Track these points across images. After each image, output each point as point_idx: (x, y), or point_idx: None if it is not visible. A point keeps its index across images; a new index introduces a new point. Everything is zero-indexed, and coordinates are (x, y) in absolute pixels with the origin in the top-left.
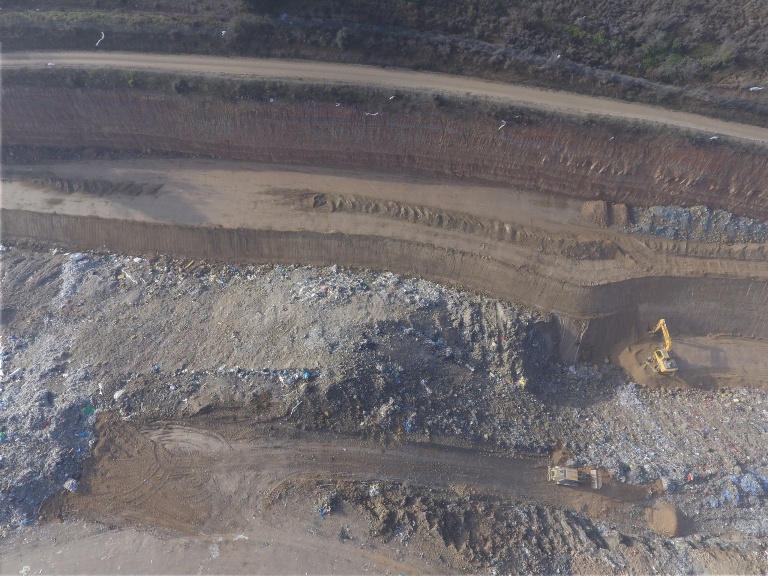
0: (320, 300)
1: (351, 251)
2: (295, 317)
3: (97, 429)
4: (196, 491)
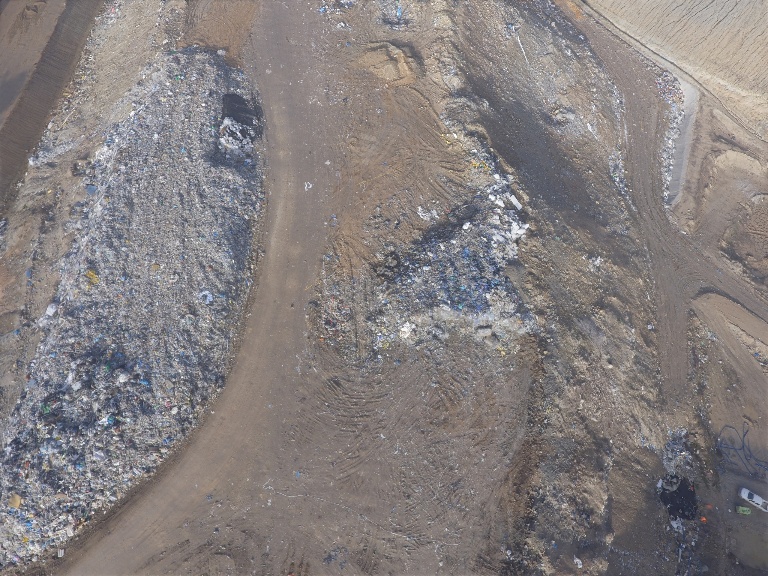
0: (122, 3)
1: (86, 5)
2: (132, 7)
3: (187, 46)
4: (235, 3)
